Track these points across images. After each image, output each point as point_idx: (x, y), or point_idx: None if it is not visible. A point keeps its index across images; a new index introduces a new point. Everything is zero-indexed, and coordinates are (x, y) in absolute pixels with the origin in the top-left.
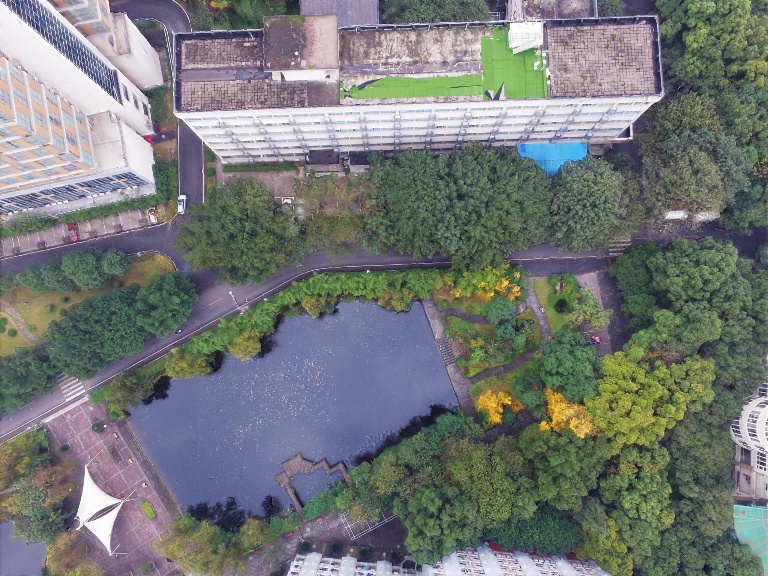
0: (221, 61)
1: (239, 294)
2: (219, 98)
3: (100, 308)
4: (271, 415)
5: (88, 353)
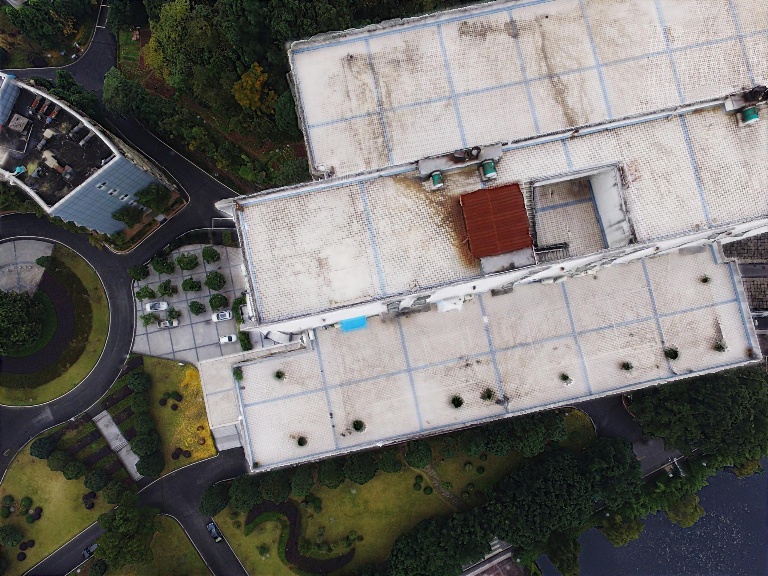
0: (759, 256)
1: (662, 453)
2: (760, 296)
3: (557, 481)
4: (689, 574)
5: (549, 529)
